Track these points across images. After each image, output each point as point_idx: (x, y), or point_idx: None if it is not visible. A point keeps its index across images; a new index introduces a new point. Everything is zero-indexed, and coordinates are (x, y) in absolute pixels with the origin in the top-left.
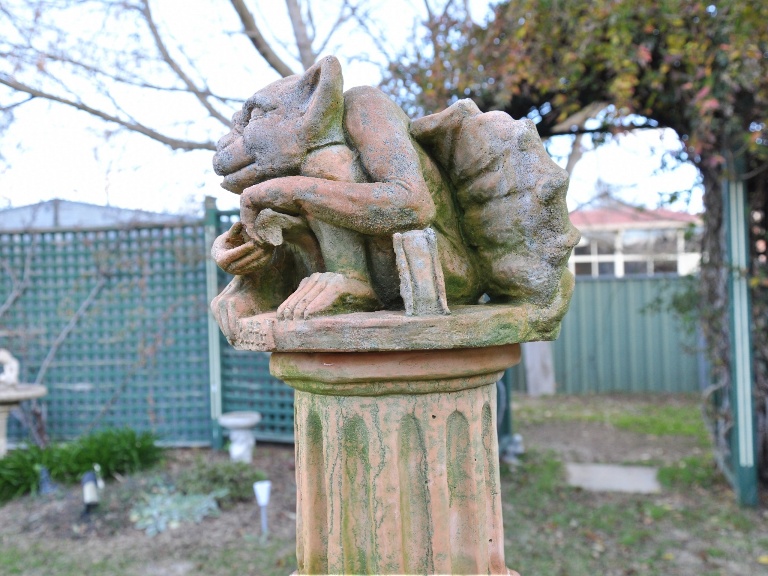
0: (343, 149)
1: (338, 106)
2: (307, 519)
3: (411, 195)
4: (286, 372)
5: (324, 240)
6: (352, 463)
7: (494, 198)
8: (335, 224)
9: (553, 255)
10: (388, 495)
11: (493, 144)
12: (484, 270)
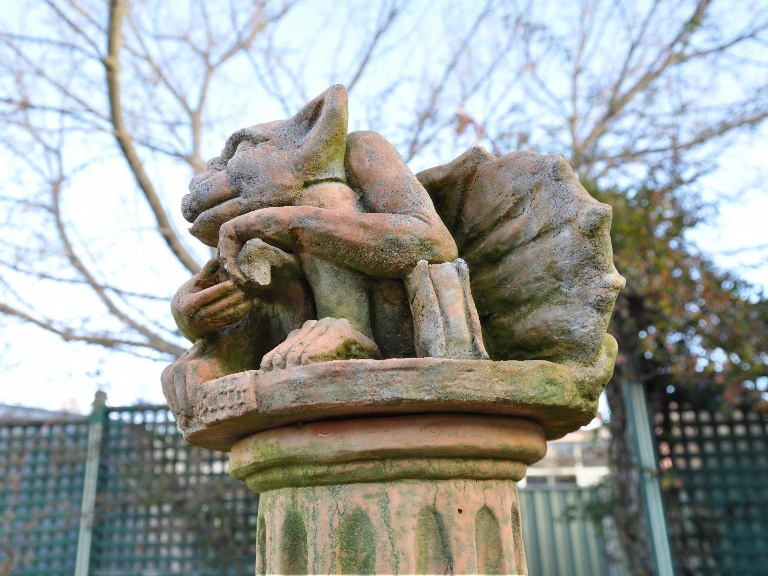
0: (345, 186)
1: (343, 138)
2: None
3: (431, 228)
4: (261, 455)
5: (321, 282)
6: None
7: (516, 247)
8: (337, 262)
9: (600, 297)
10: None
11: (518, 183)
12: (500, 339)
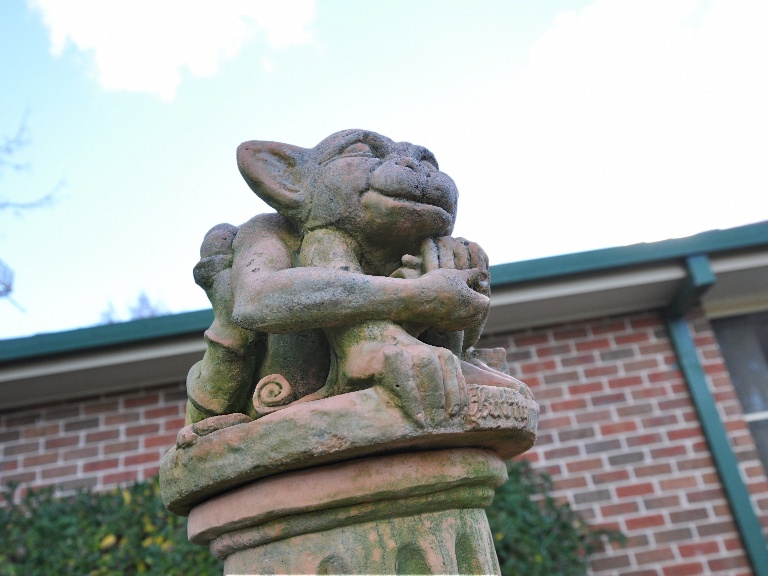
0: None
1: None
2: None
3: None
4: (474, 471)
5: None
6: None
7: None
8: None
9: None
10: None
11: None
12: None
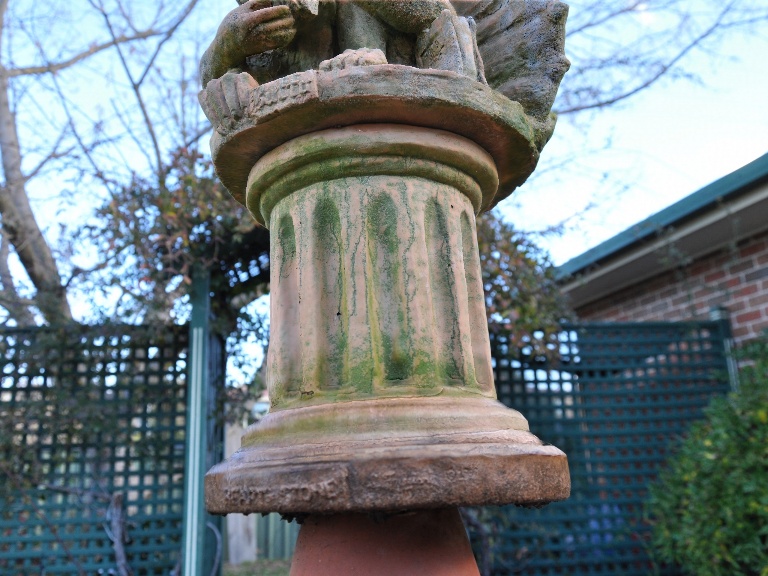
0: None
1: None
2: (313, 315)
3: None
4: (304, 149)
5: (356, 25)
6: (373, 246)
7: (491, 37)
8: (370, 10)
9: (556, 69)
10: (419, 269)
11: None
12: None
